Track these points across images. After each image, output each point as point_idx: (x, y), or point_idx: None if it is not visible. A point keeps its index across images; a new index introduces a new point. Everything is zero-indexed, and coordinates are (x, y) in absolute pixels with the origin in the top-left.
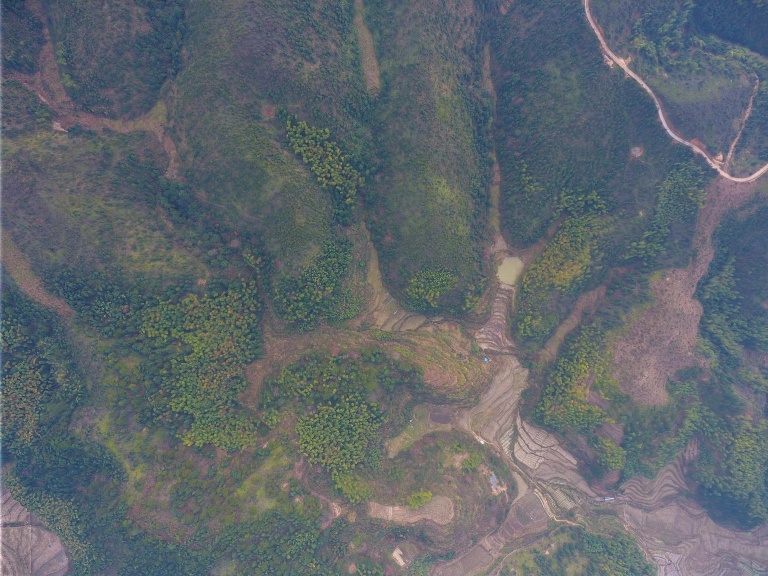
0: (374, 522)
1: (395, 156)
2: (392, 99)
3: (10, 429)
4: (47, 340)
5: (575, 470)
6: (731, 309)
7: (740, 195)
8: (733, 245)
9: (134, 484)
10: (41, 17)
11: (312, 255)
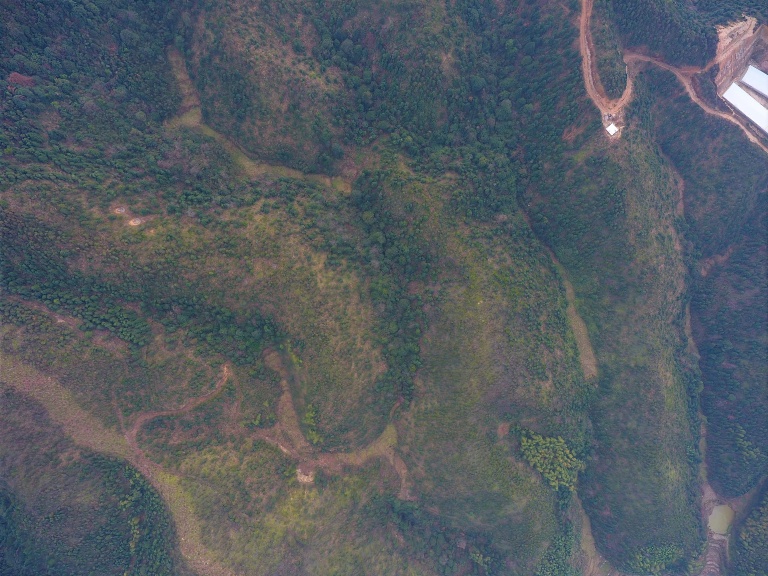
0: None
1: (615, 439)
2: (616, 392)
3: None
4: None
5: None
6: None
7: None
8: None
9: None
10: (280, 371)
11: (543, 551)
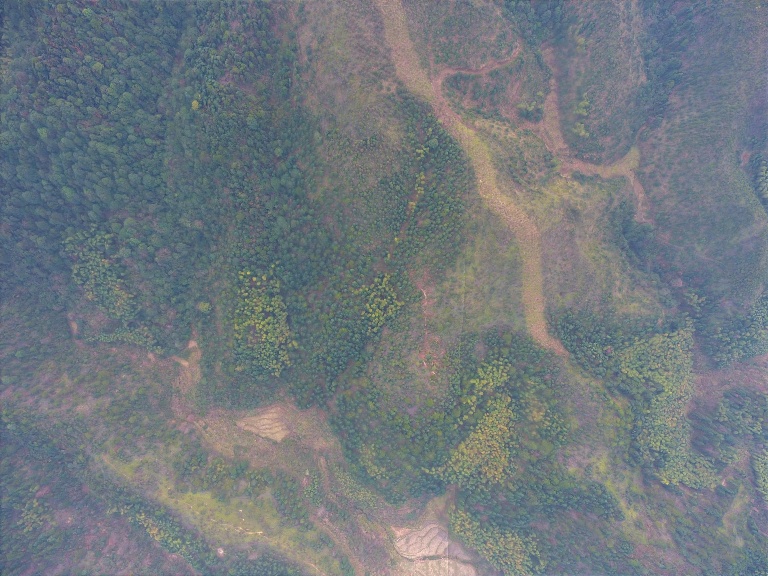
0: None
1: None
2: None
3: (475, 466)
4: (535, 380)
5: None
6: None
7: None
8: None
9: (634, 523)
10: (551, 68)
11: (758, 295)
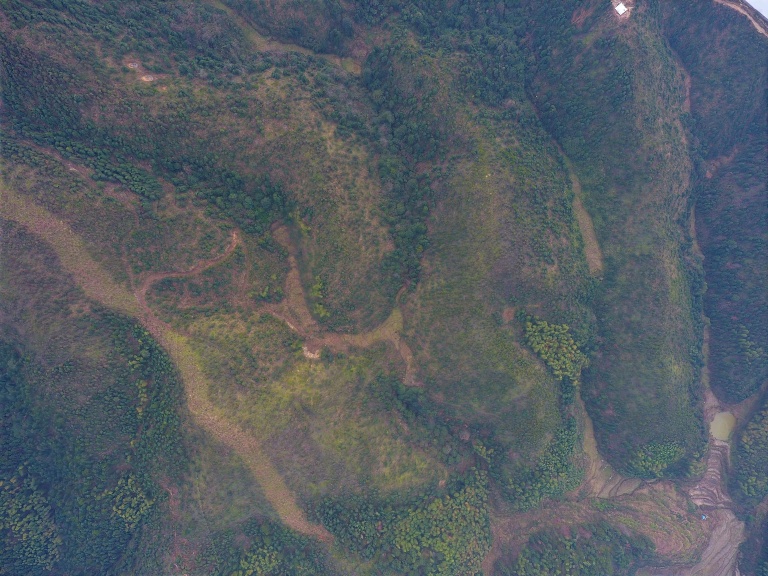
0: None
1: (619, 335)
2: (621, 284)
3: None
4: (304, 564)
5: None
6: None
7: None
8: None
9: None
10: (288, 247)
11: (546, 443)
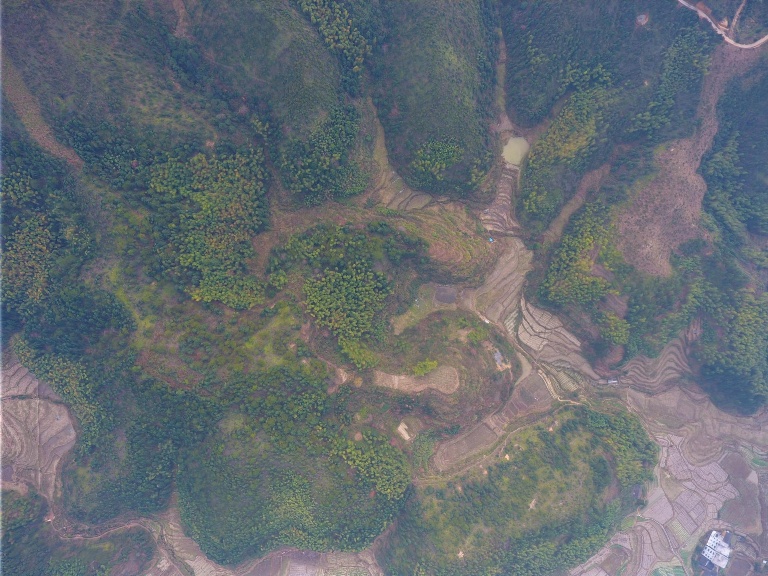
0: (380, 391)
1: (402, 24)
2: None
3: (19, 288)
4: (56, 193)
5: (579, 352)
6: (734, 186)
7: (745, 61)
8: (737, 119)
9: (143, 332)
10: None
11: (319, 120)
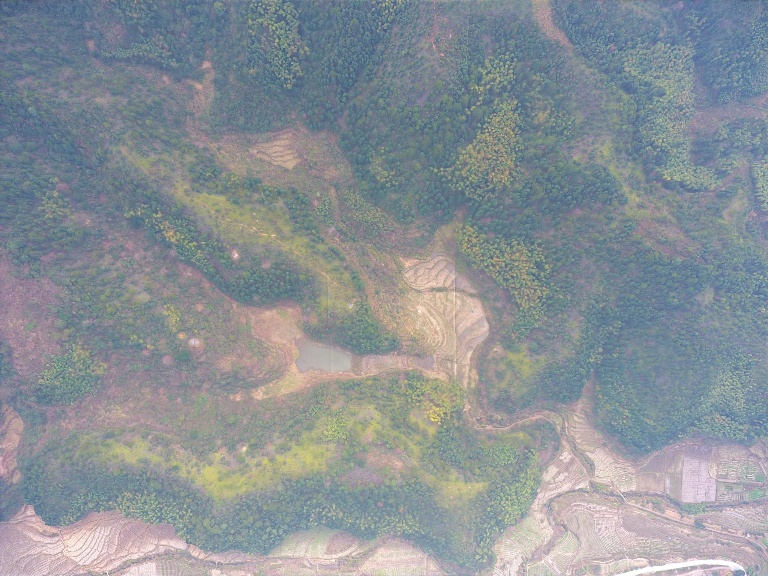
0: None
1: None
2: None
3: (481, 172)
4: (540, 75)
5: None
6: None
7: None
8: None
9: (637, 204)
10: None
11: (757, 14)
